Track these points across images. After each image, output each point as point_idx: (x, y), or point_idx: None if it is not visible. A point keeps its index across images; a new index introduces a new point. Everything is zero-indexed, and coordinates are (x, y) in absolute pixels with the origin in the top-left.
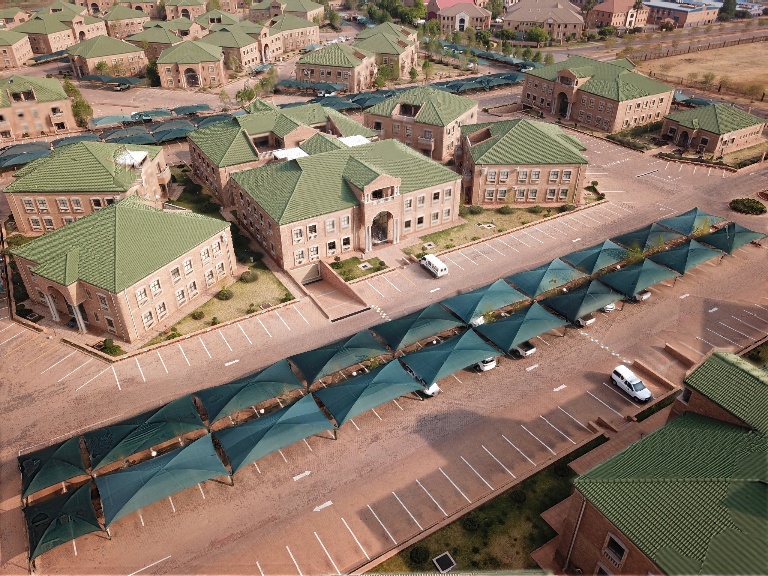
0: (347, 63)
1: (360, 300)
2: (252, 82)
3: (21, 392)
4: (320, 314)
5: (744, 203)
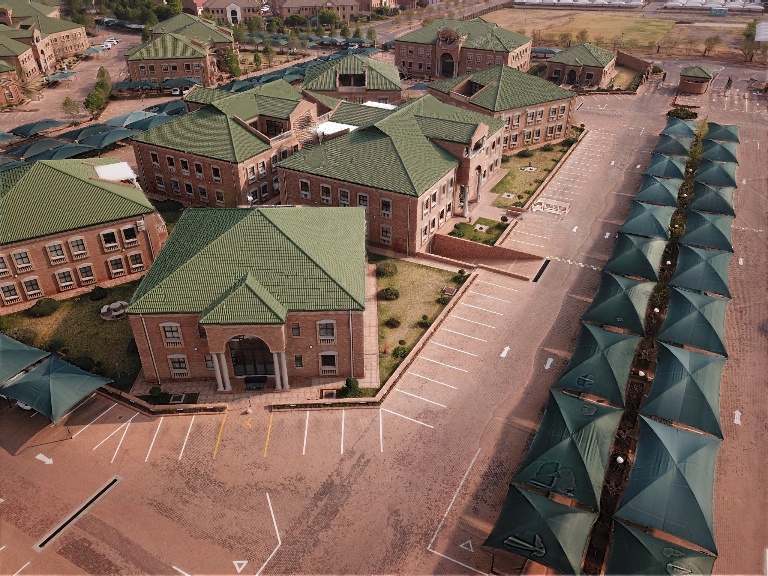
0: (195, 53)
1: (529, 256)
2: (61, 93)
3: (312, 486)
4: (515, 279)
5: (679, 112)
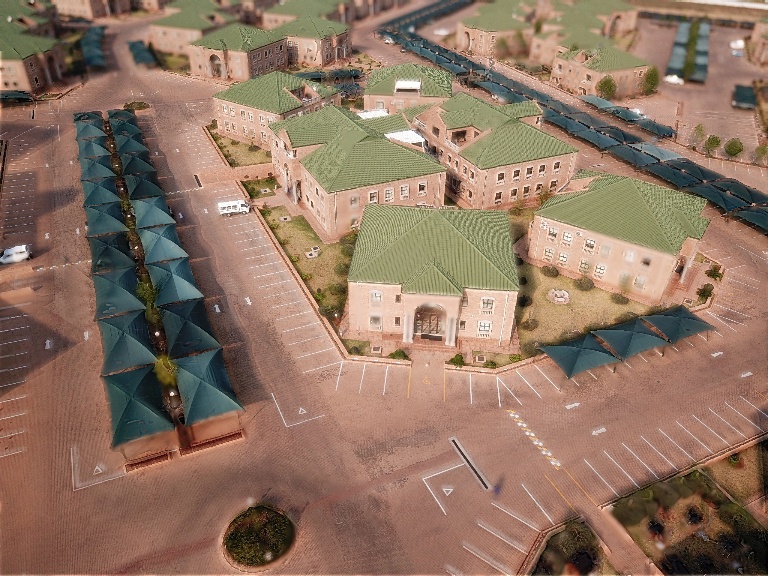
0: None
1: None
2: None
3: None
4: None
5: (265, 528)
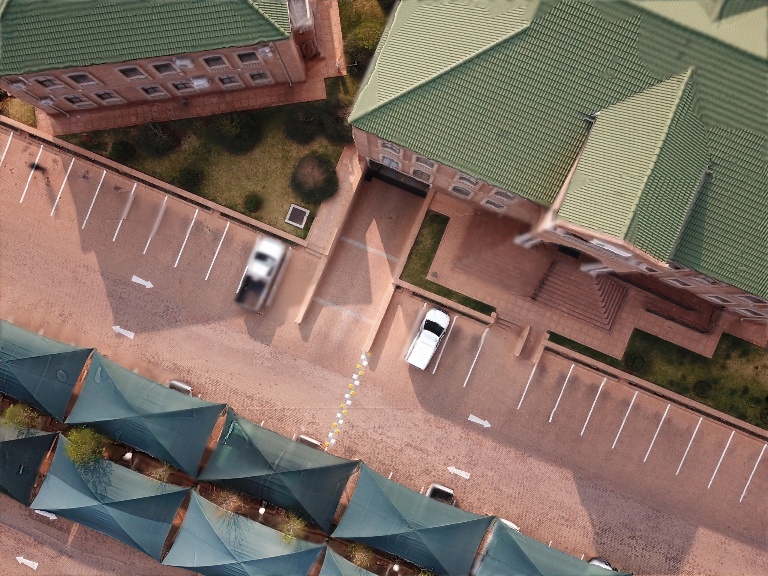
0: None
1: None
2: None
3: None
4: None
5: None
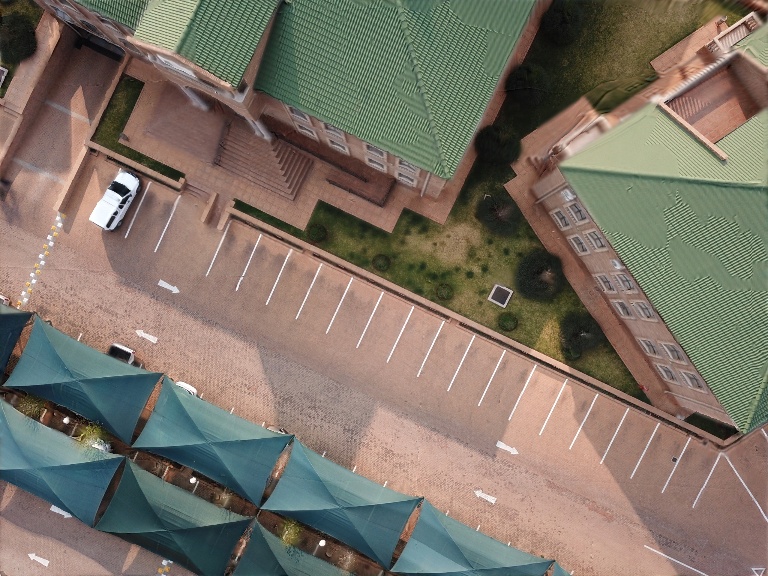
0: None
1: None
2: None
3: None
4: None
5: None
